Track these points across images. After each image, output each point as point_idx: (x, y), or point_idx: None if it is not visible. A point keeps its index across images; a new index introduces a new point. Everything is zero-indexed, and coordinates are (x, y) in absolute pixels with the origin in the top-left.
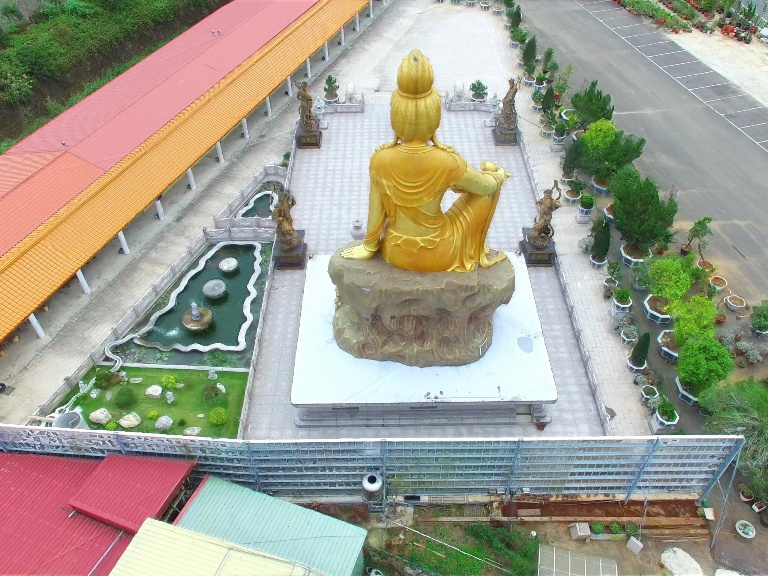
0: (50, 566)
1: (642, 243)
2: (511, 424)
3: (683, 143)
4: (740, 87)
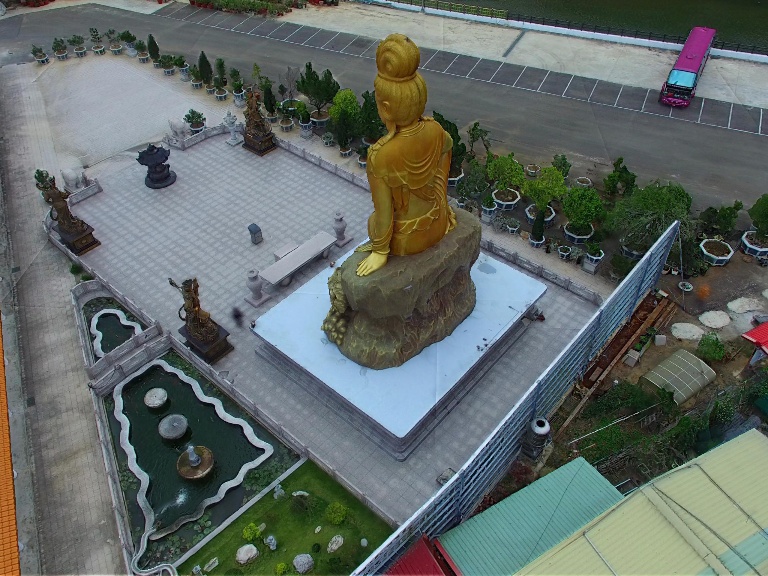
0: None
1: (455, 163)
2: (525, 331)
3: None
4: (368, 37)
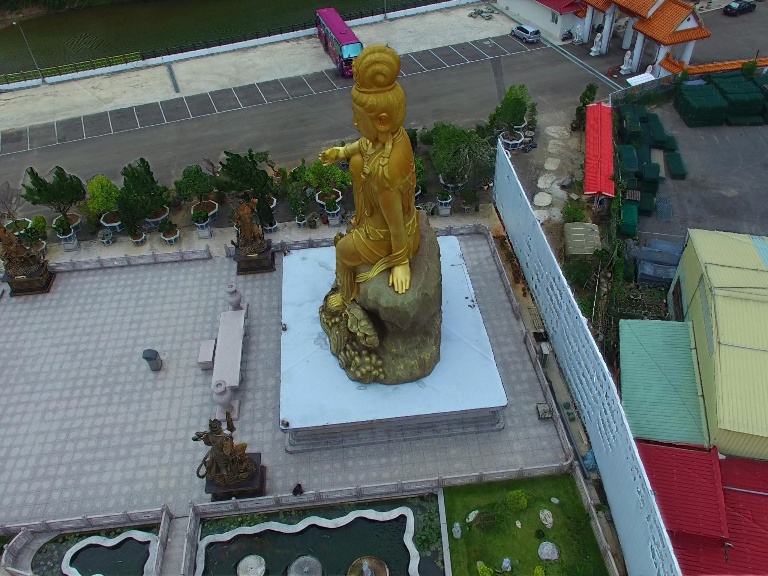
0: None
1: None
2: None
3: (96, 169)
4: (13, 128)
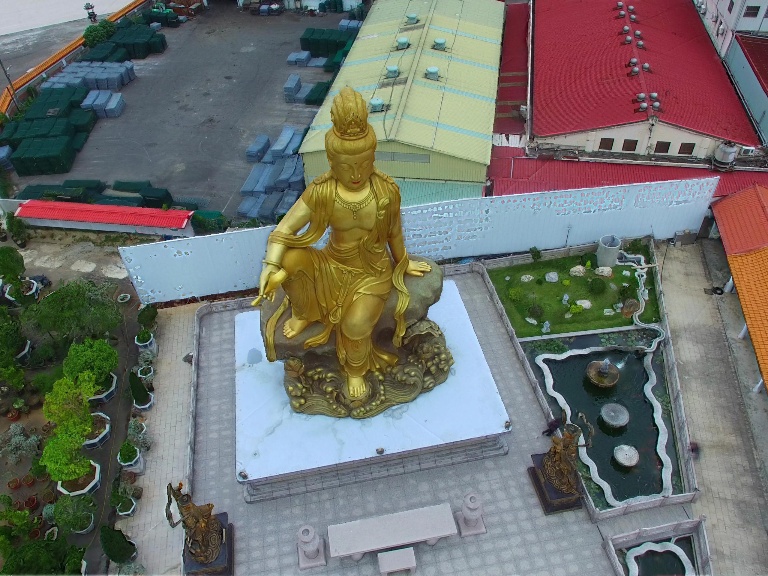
0: (537, 169)
1: None
2: None
3: None
4: None
